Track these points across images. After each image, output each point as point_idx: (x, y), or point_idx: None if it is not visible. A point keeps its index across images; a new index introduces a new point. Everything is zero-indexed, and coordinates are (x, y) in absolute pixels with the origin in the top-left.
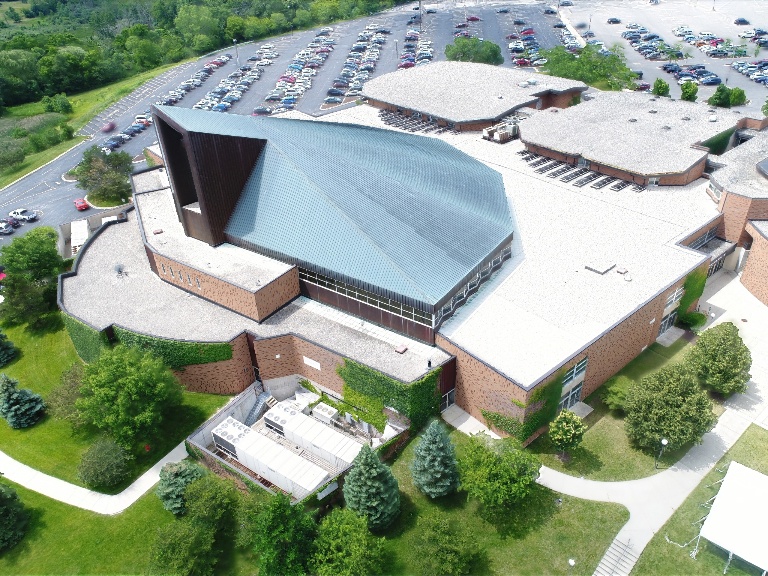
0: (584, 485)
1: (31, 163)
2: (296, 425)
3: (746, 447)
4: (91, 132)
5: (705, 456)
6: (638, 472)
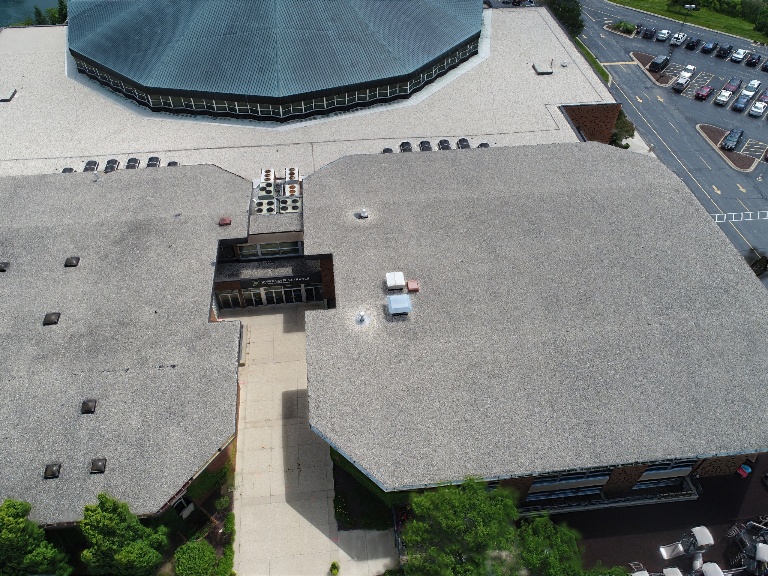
0: None
1: (688, 16)
2: None
3: None
4: None
5: None
6: None
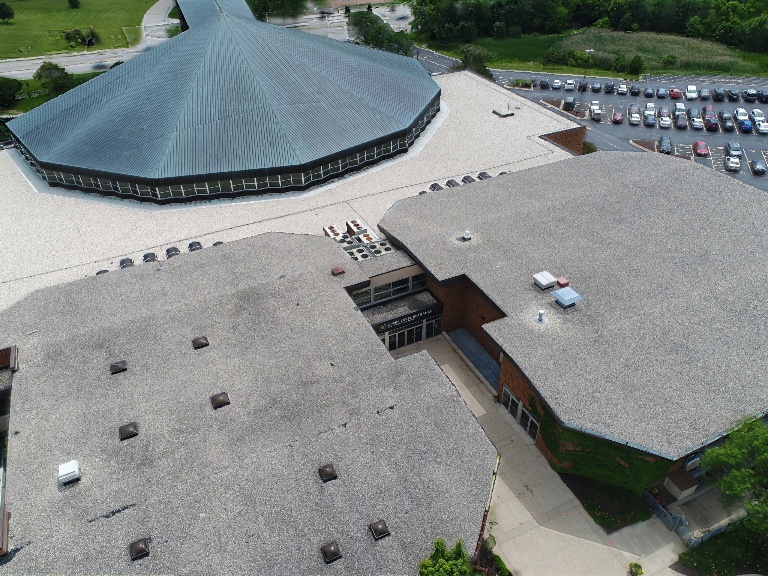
0: None
1: None
2: None
3: None
4: (653, 79)
5: None
6: None
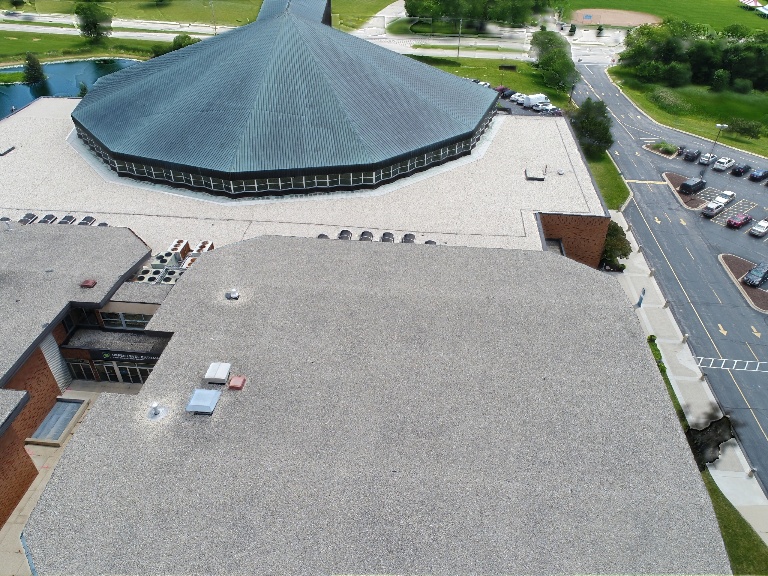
0: None
1: (744, 143)
2: None
3: None
4: None
5: None
6: None
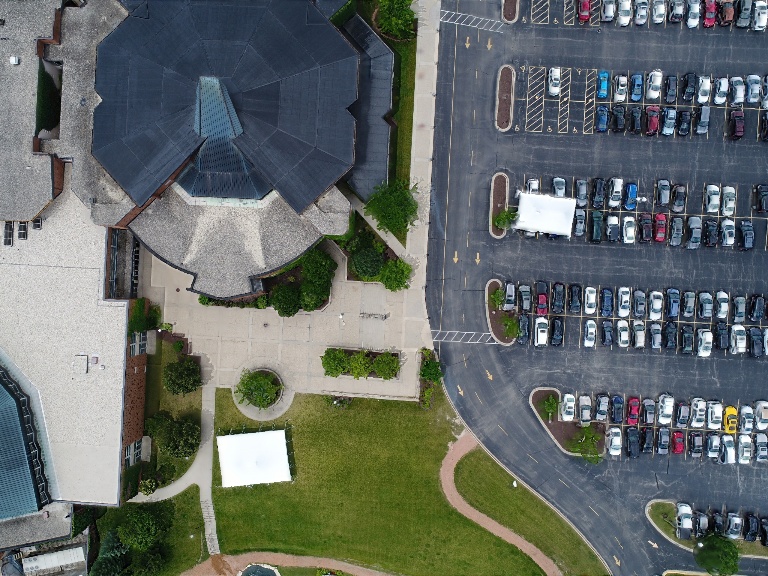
0: (175, 486)
1: None
2: (44, 564)
3: (220, 408)
4: None
5: (208, 428)
6: (189, 461)
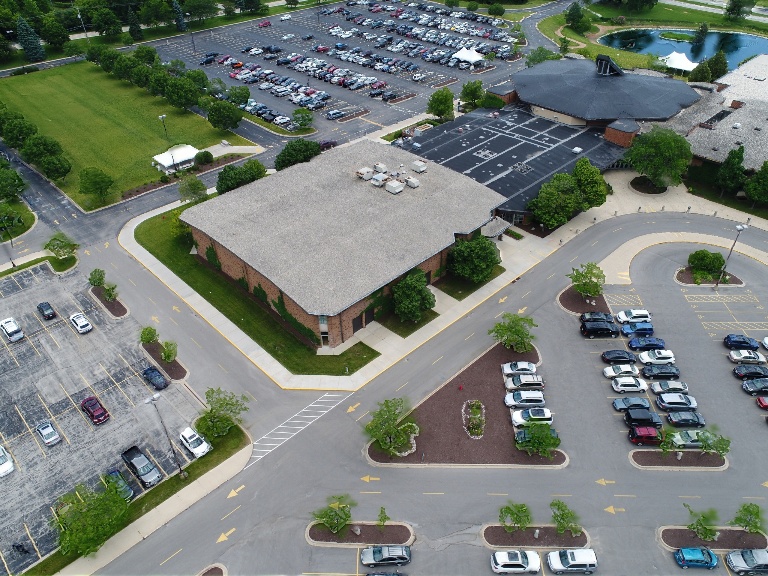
0: None
1: None
2: None
3: None
4: None
5: None
6: None
